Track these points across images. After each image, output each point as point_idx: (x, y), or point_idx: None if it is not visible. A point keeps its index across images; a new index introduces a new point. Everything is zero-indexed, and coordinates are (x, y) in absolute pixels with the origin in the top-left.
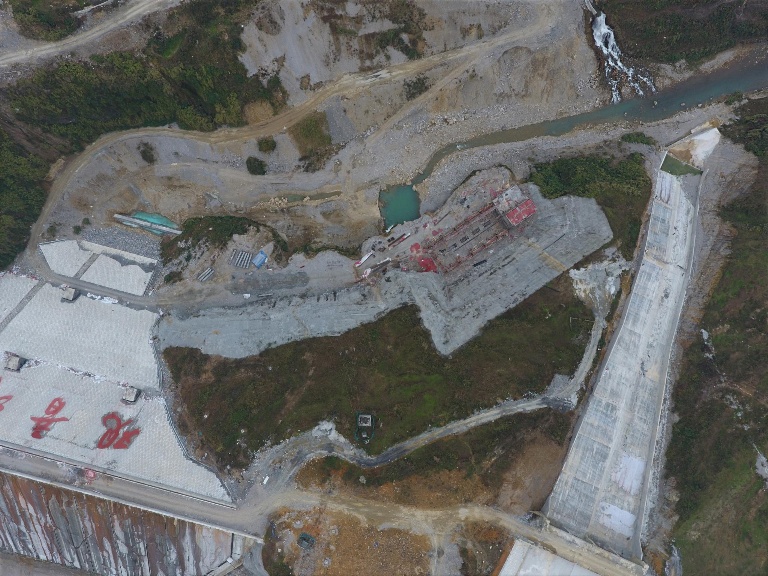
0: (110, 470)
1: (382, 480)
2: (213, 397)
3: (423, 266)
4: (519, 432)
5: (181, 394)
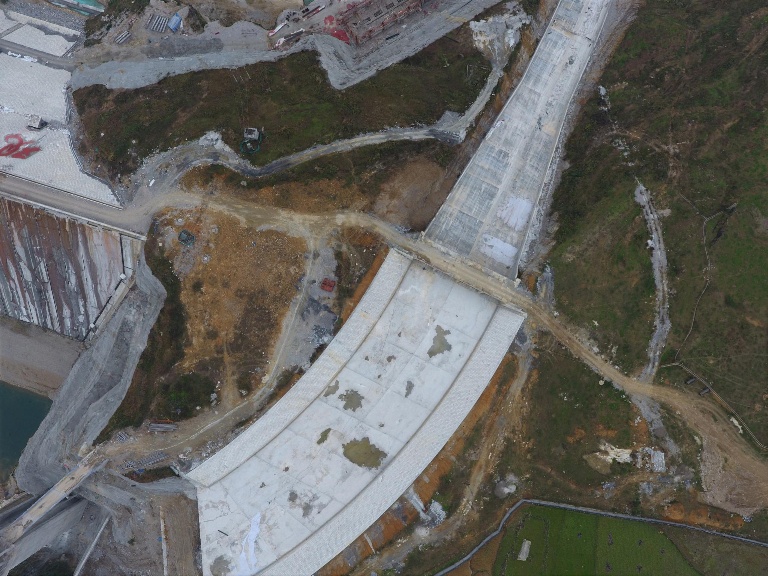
0: (5, 170)
1: (262, 184)
2: (110, 117)
3: (335, 36)
4: (402, 153)
5: (83, 122)
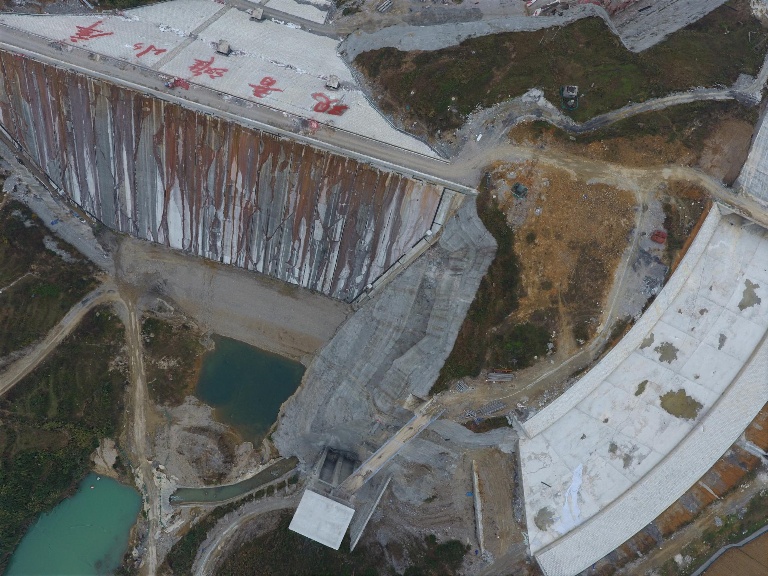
0: None
1: (591, 139)
2: (419, 76)
3: None
4: (713, 112)
5: (382, 82)
